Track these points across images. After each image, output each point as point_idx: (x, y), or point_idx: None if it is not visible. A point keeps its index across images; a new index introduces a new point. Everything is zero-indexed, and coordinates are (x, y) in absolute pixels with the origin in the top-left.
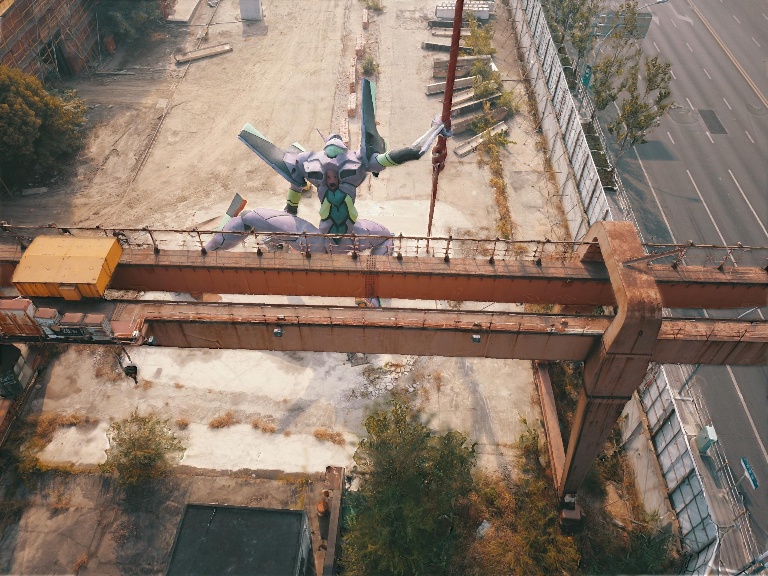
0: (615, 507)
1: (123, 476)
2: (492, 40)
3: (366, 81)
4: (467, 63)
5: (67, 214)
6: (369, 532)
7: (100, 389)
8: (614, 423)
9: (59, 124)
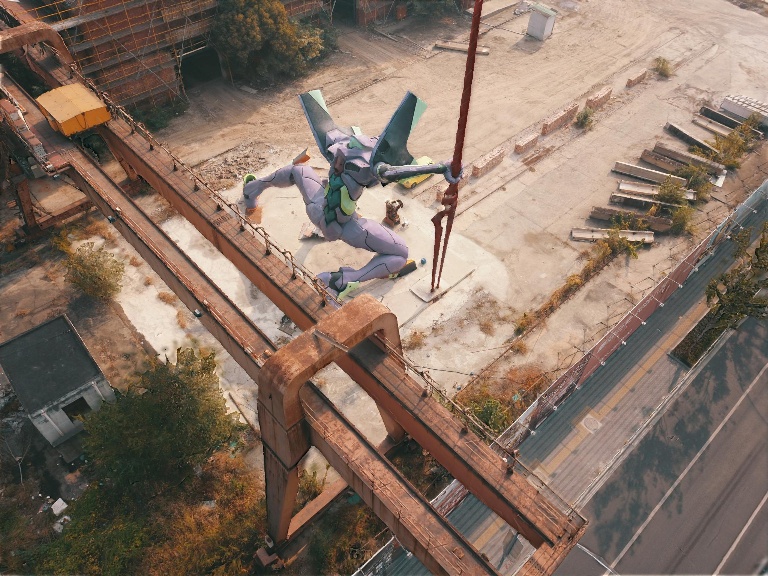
0: None
1: (66, 276)
2: (756, 155)
3: (412, 96)
4: (693, 163)
5: (248, 114)
6: None
7: None
8: (285, 488)
9: (281, 47)
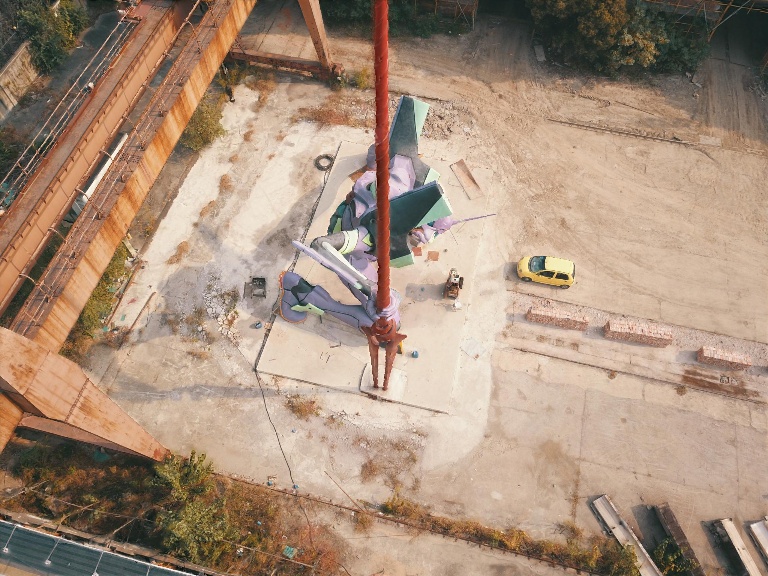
0: (1, 479)
1: None
2: None
3: (436, 189)
4: None
5: (502, 77)
6: None
7: (287, 111)
8: None
9: (587, 31)
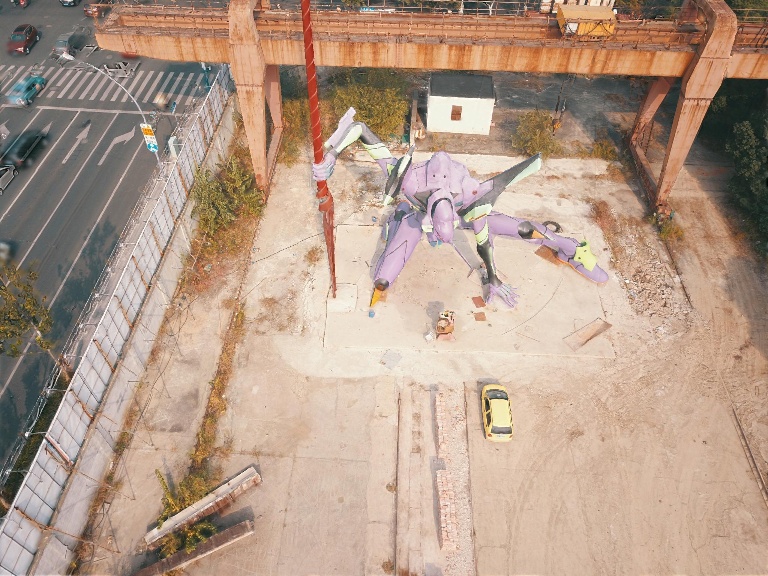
0: None
1: None
2: None
3: None
4: None
5: None
6: (396, 81)
7: (596, 195)
8: None
9: None
